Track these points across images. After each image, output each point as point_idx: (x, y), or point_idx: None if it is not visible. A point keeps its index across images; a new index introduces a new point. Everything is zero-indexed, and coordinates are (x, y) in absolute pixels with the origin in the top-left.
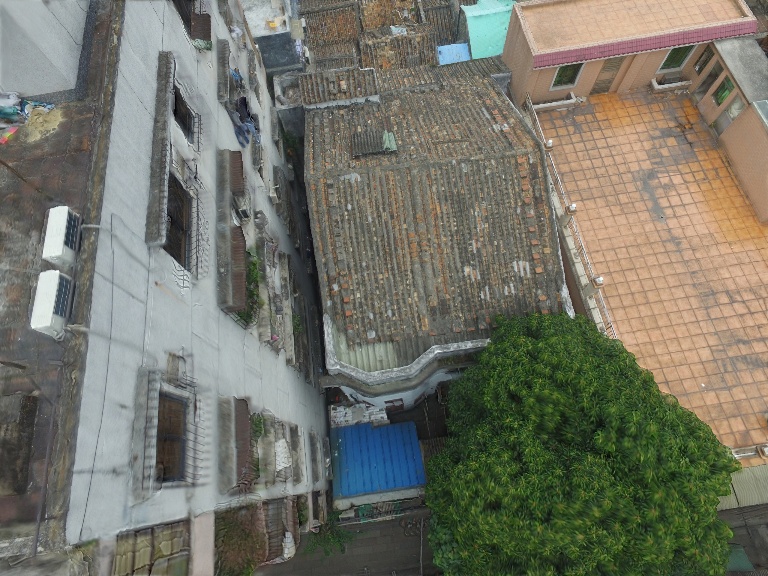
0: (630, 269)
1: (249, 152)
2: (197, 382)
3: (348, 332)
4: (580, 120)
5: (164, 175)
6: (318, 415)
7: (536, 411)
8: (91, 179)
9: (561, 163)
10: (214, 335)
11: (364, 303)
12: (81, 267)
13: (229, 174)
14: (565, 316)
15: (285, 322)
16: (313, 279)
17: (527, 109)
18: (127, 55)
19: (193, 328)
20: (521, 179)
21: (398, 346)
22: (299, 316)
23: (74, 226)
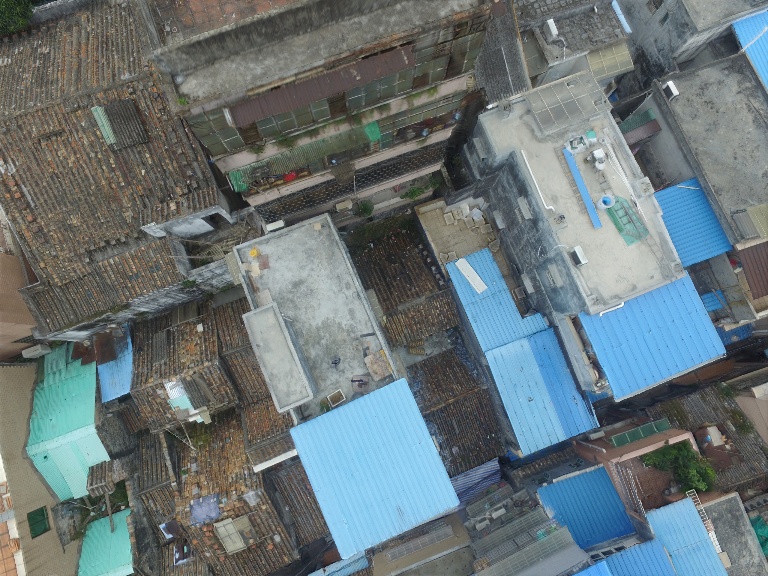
0: None
1: None
2: None
3: None
4: None
5: None
6: None
7: None
8: None
9: None
10: None
11: None
12: None
13: None
14: None
15: None
16: None
17: (6, 248)
18: None
19: None
20: None
21: None
22: None
23: None
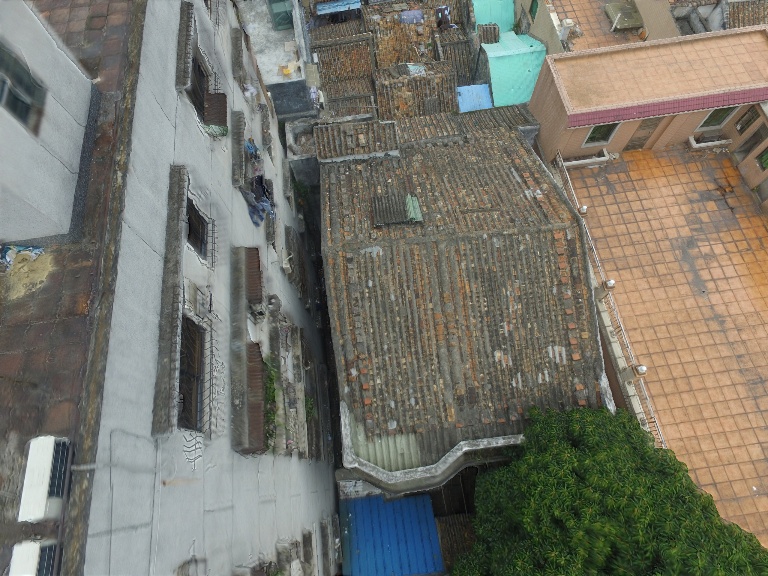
0: (671, 351)
1: (262, 227)
2: (209, 573)
3: (367, 422)
4: (613, 179)
5: (176, 338)
6: (327, 490)
7: (585, 544)
8: (85, 388)
9: (594, 227)
10: (228, 491)
11: (385, 390)
12: (69, 531)
13: (245, 278)
14: (607, 413)
15: (297, 408)
16: (322, 333)
17: (557, 166)
18: (133, 194)
19: (205, 504)
20: (558, 256)
21: (421, 437)
22: (312, 399)
23: (62, 461)
